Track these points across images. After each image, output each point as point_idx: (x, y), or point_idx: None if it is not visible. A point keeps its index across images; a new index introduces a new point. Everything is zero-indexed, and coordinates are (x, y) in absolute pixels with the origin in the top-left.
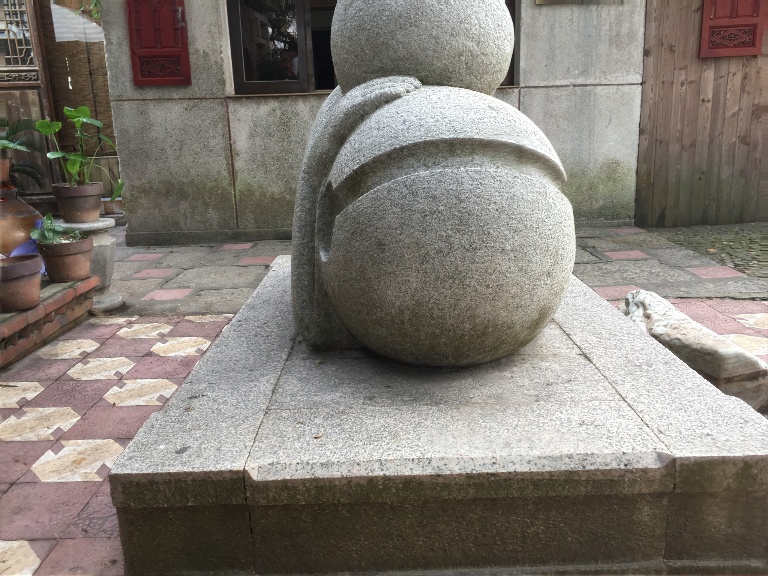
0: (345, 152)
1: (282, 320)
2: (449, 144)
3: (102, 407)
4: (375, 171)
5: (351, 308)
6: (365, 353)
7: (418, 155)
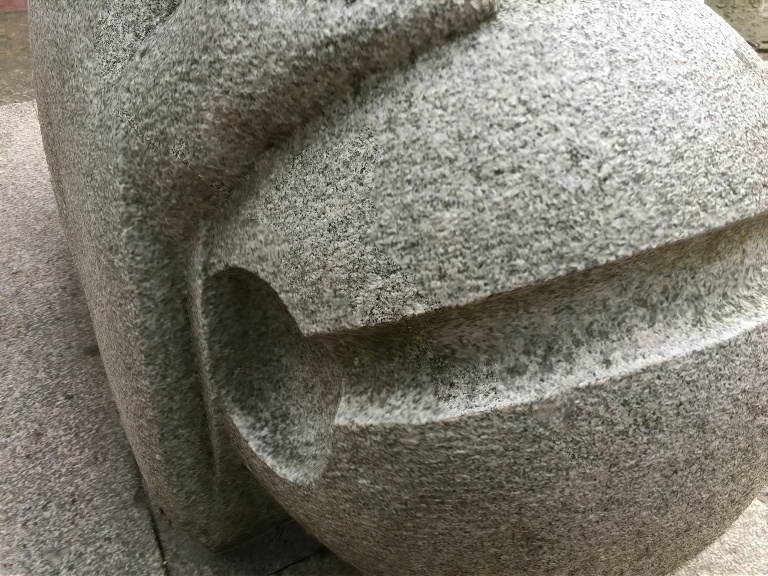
0: (326, 216)
1: (71, 409)
2: (713, 234)
3: None
4: (476, 316)
5: None
6: None
7: (626, 275)
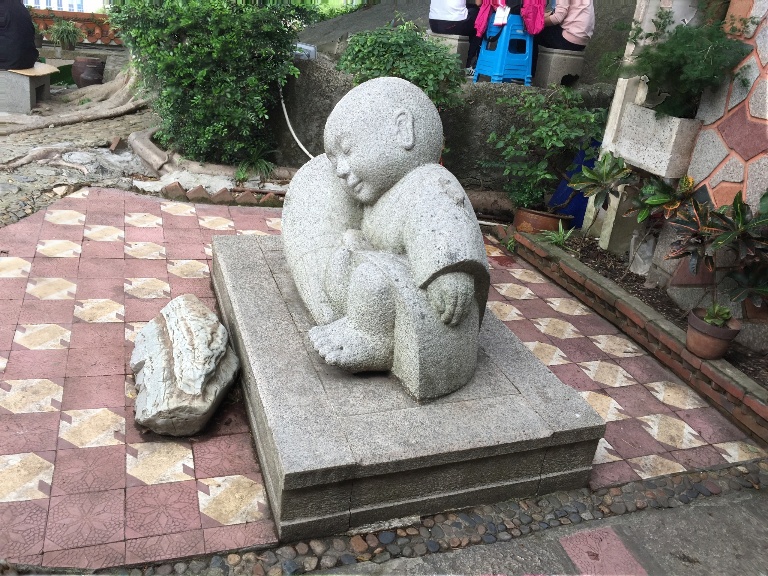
0: None
1: None
2: None
3: (544, 339)
4: None
5: None
6: None
7: None
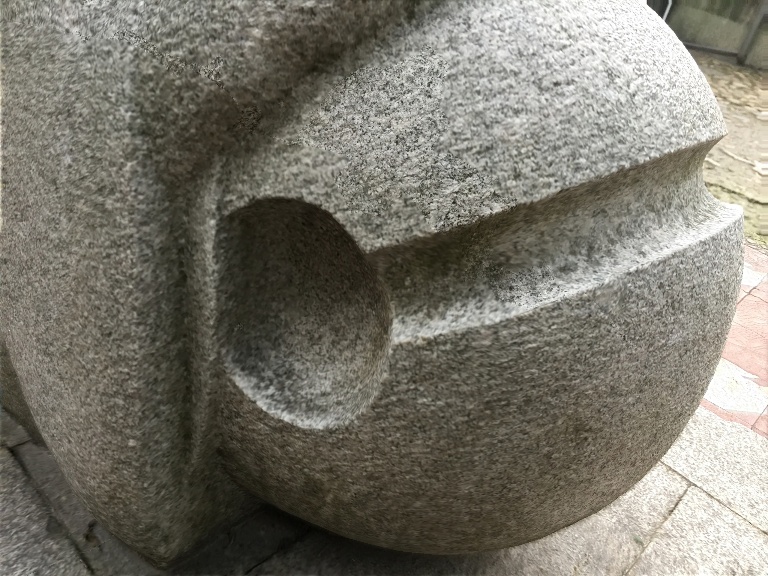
0: (393, 129)
1: None
2: (694, 152)
3: None
4: (535, 219)
5: (398, 530)
6: (283, 519)
7: (644, 181)
